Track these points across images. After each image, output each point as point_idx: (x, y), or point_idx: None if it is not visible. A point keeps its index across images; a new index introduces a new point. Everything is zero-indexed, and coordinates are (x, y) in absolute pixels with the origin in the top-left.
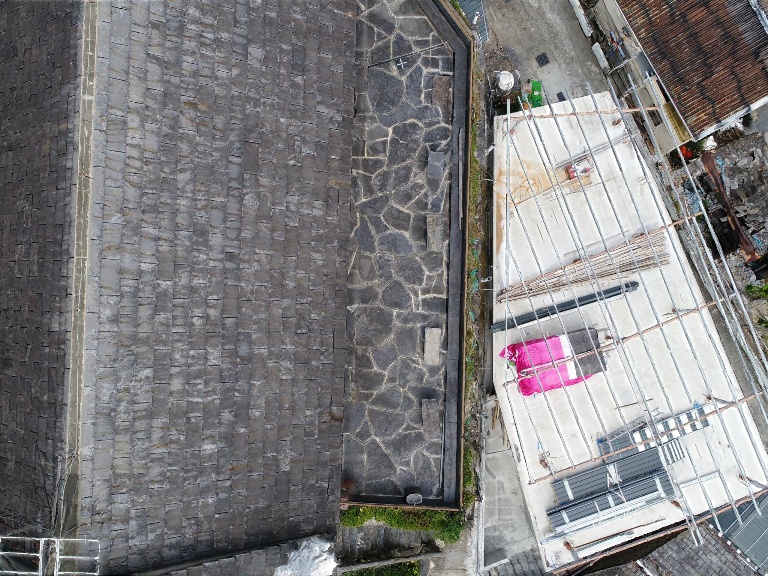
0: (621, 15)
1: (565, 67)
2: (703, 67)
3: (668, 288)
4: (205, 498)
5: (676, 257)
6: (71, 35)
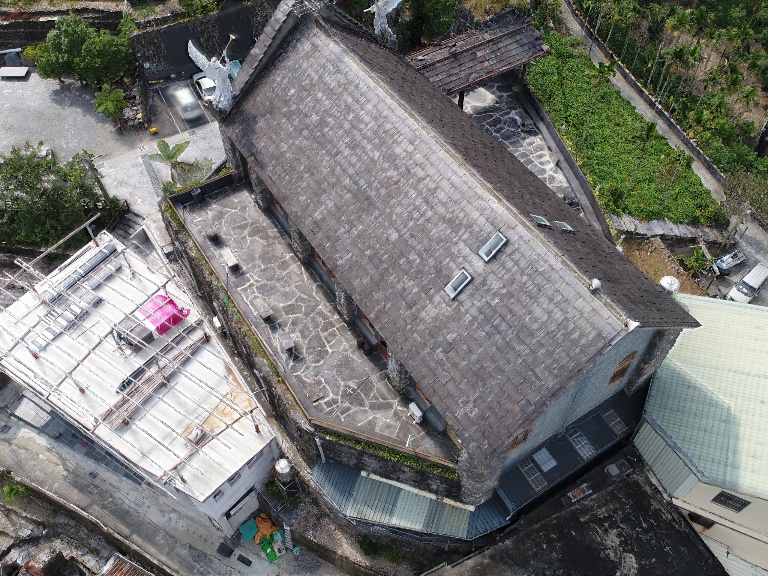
0: None
1: None
2: None
3: None
4: (281, 78)
5: None
6: None
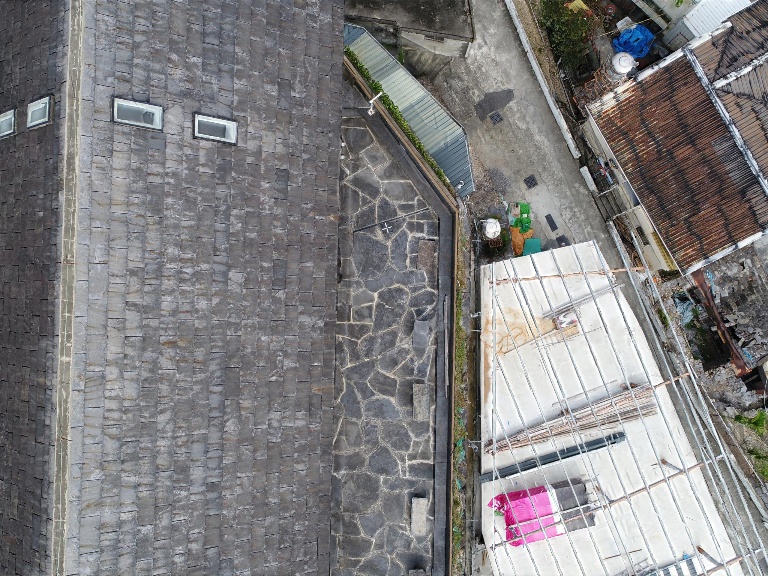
0: (608, 148)
1: (553, 189)
2: (690, 204)
3: (655, 451)
4: None
5: (664, 407)
6: (49, 290)
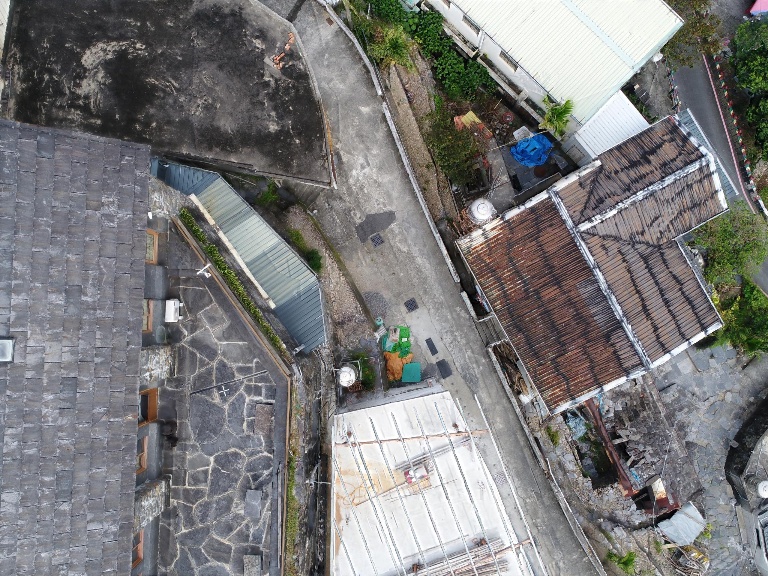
0: None
1: (434, 312)
2: (557, 344)
3: None
4: None
5: (515, 563)
6: None
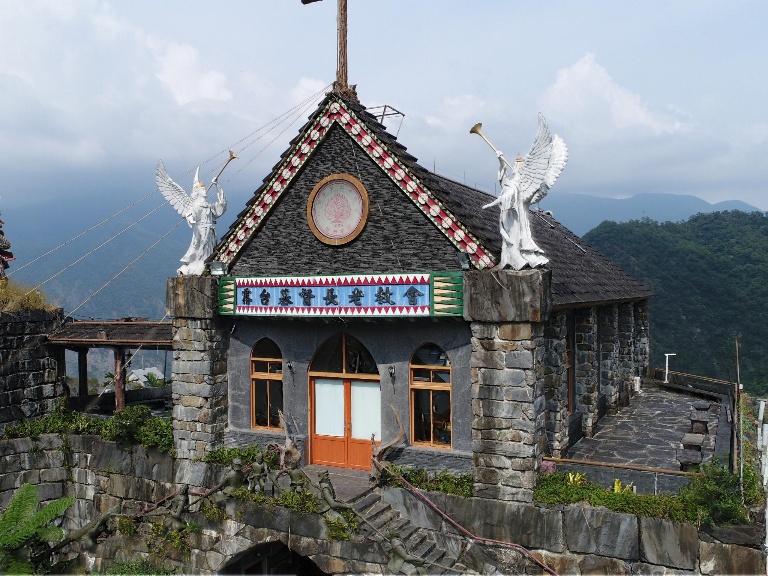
0: None
1: None
2: None
3: None
4: None
5: None
6: None
